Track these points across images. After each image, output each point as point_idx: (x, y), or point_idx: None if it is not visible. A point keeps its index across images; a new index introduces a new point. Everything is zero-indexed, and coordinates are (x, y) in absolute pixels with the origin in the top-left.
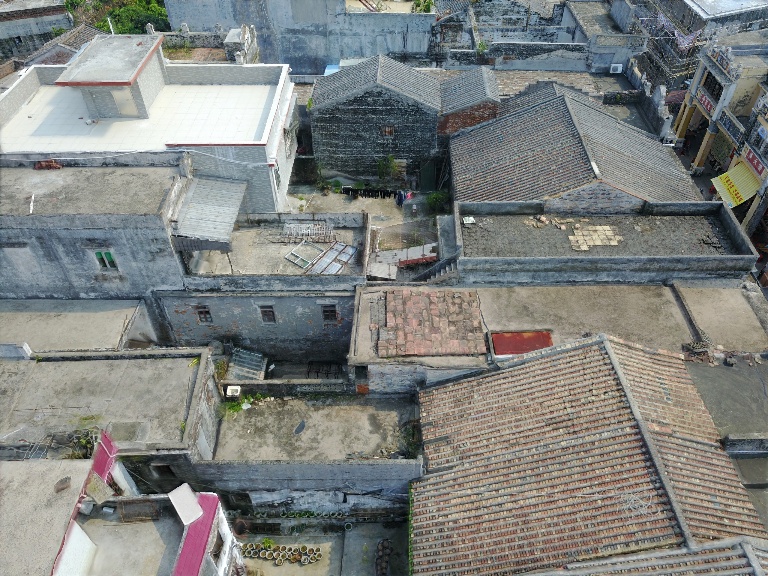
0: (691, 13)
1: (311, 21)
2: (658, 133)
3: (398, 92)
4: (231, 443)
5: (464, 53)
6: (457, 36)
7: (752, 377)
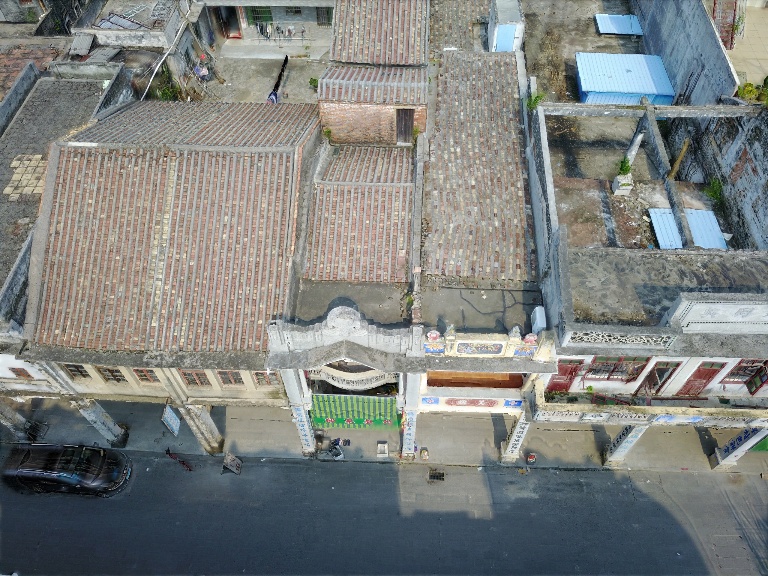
0: None
1: None
2: None
3: None
4: (13, 29)
5: None
6: (727, 144)
7: None
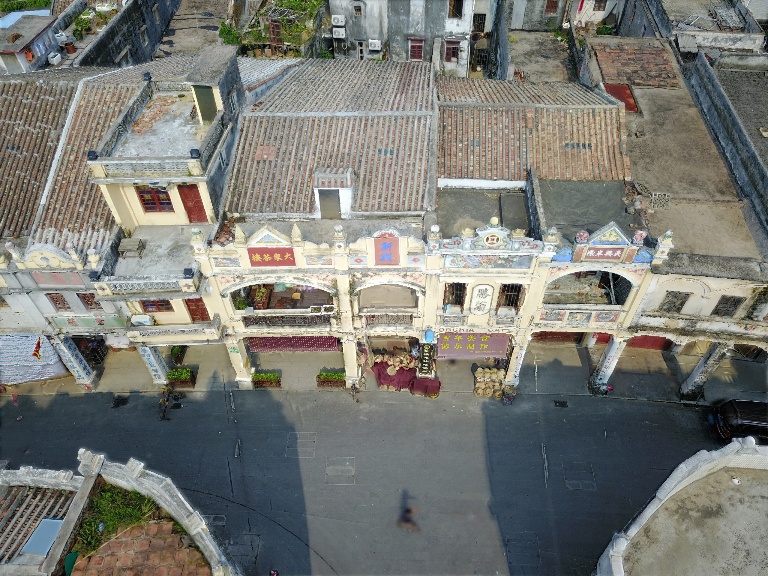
0: None
1: None
2: None
3: None
4: (531, 36)
5: None
6: None
7: (614, 221)
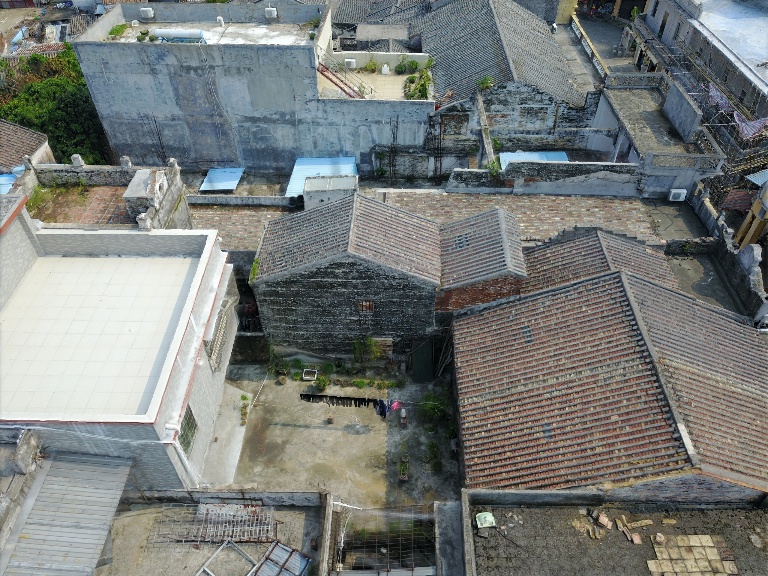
0: (757, 93)
1: (275, 108)
2: (751, 314)
3: (379, 263)
4: None
5: (472, 173)
6: (461, 128)
7: None
